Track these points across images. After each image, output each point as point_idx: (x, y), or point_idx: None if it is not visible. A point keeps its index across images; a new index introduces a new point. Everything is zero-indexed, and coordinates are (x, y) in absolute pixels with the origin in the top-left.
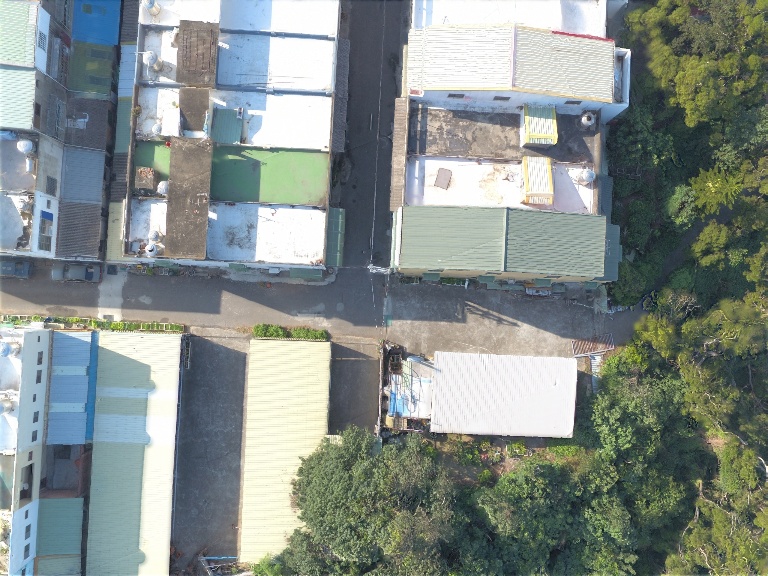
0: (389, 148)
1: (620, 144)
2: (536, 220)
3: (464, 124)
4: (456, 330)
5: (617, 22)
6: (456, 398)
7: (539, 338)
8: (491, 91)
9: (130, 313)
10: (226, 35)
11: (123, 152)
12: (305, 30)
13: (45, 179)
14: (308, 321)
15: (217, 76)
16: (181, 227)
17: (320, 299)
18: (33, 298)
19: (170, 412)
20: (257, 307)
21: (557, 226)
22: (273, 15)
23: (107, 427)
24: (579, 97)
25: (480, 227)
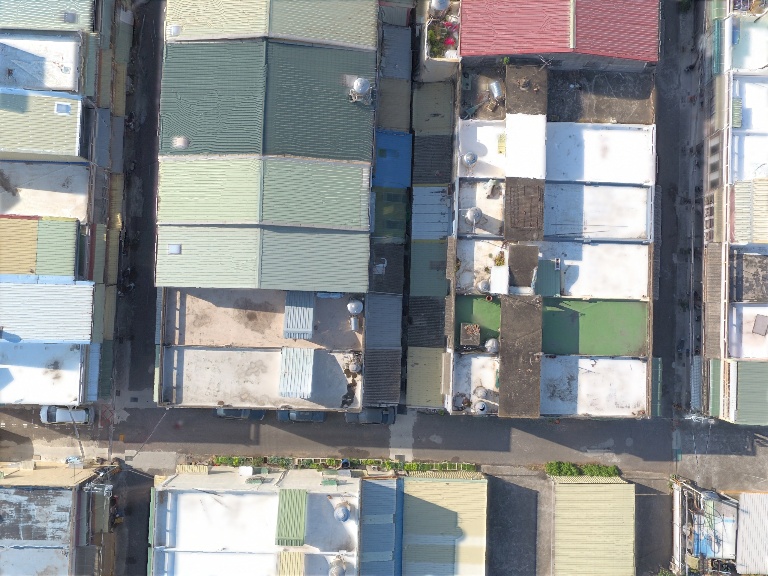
0: (672, 279)
1: None
2: None
3: None
4: (746, 463)
5: None
6: (763, 539)
7: None
8: None
9: (421, 453)
10: None
11: (420, 296)
12: (619, 178)
13: None
14: (598, 457)
15: None
16: (514, 386)
17: (609, 434)
18: (325, 440)
19: (478, 559)
20: (546, 444)
21: None
22: (586, 163)
23: (415, 575)
24: None
25: None
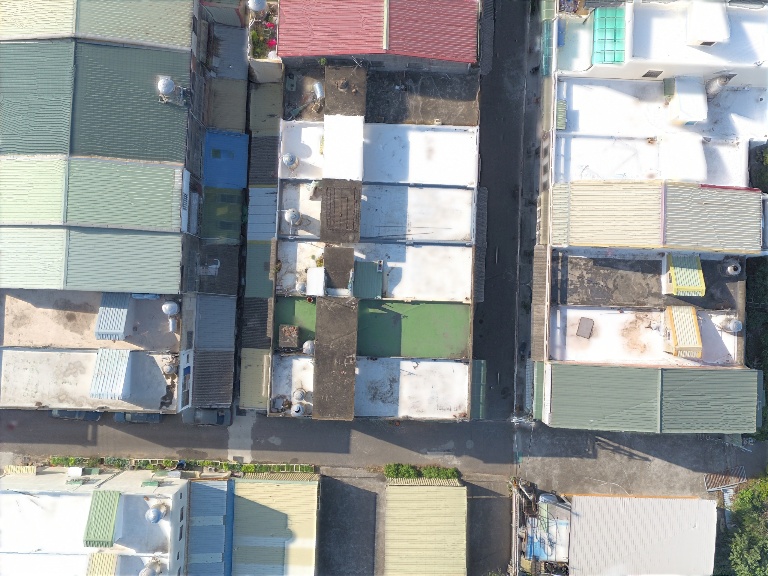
0: (515, 281)
1: (759, 284)
2: (689, 378)
3: (605, 272)
4: (587, 466)
5: (749, 155)
6: (595, 542)
7: (671, 473)
8: (640, 247)
9: (260, 454)
10: (364, 186)
11: (254, 297)
12: (443, 180)
13: (186, 336)
14: (438, 459)
15: None
16: (328, 388)
17: (449, 436)
18: (163, 441)
19: (308, 561)
20: (386, 446)
21: (710, 383)
22: (410, 165)
23: None
24: (729, 250)
25: (633, 387)
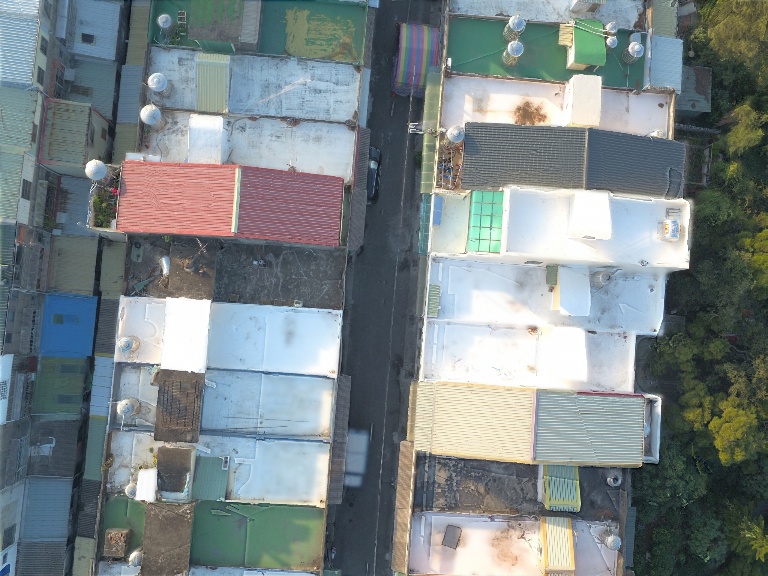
0: (390, 461)
1: (646, 486)
2: None
3: (476, 475)
4: None
5: (643, 339)
6: None
7: None
8: None
9: None
10: (213, 372)
11: (93, 479)
12: (302, 367)
13: (1, 535)
14: None
15: (201, 419)
16: None
17: None
18: None
19: None
20: None
21: None
22: (266, 349)
23: None
24: (606, 466)
25: None
